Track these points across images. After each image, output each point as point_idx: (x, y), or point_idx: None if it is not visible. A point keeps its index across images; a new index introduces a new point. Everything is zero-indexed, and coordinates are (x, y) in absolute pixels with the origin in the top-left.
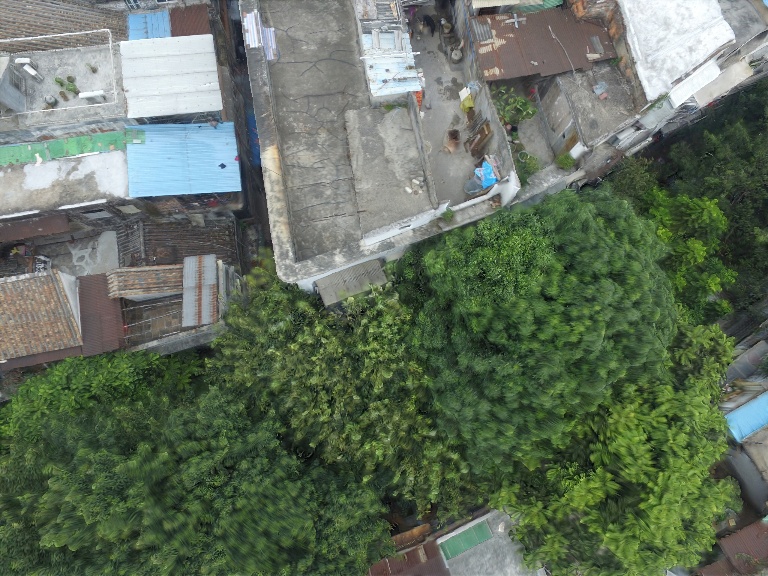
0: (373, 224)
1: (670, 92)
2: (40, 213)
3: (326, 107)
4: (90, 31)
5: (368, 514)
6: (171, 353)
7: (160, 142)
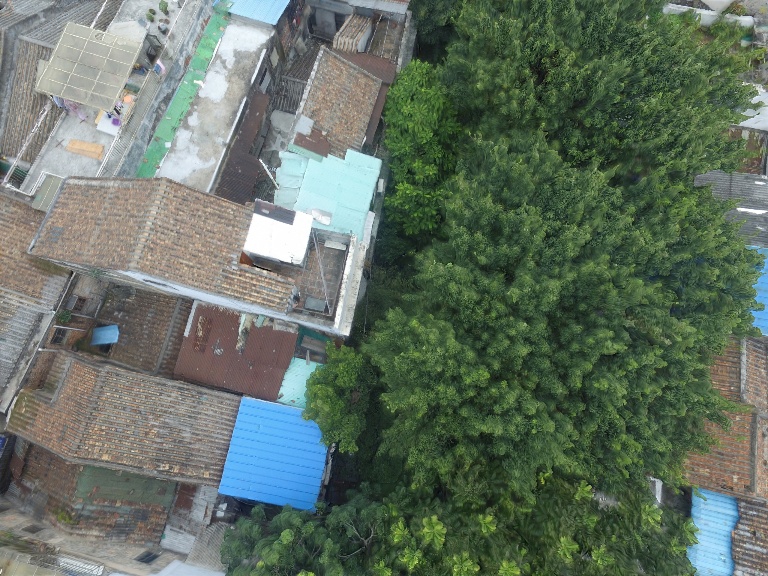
0: None
1: None
2: (247, 100)
3: None
4: None
5: None
6: None
7: None
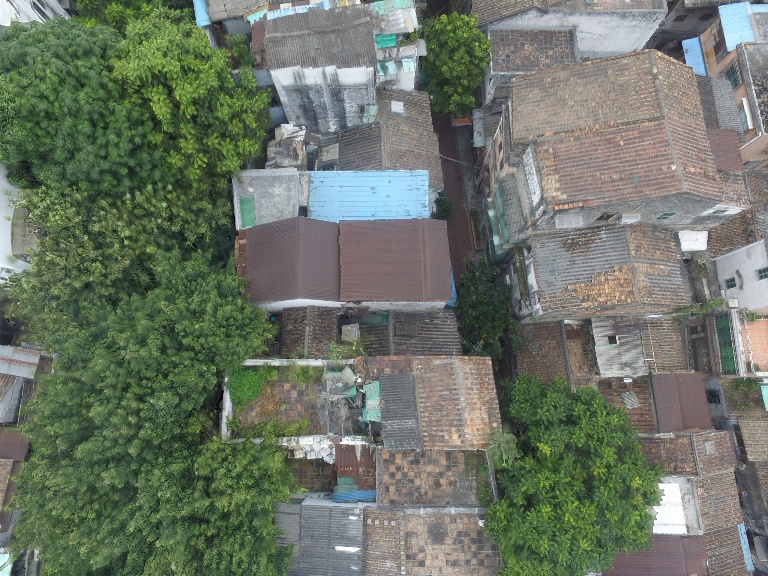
0: None
1: None
2: None
3: None
4: None
5: None
6: None
7: None
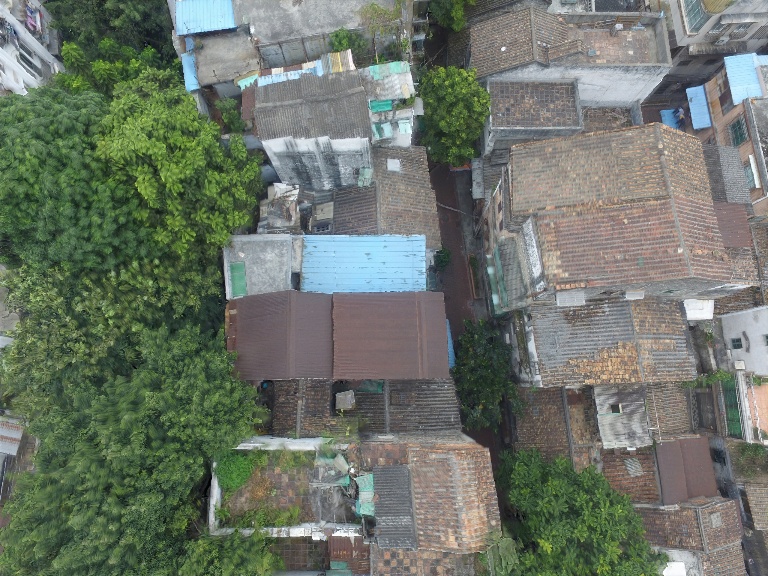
0: None
1: None
2: None
3: None
4: None
5: None
6: None
7: None
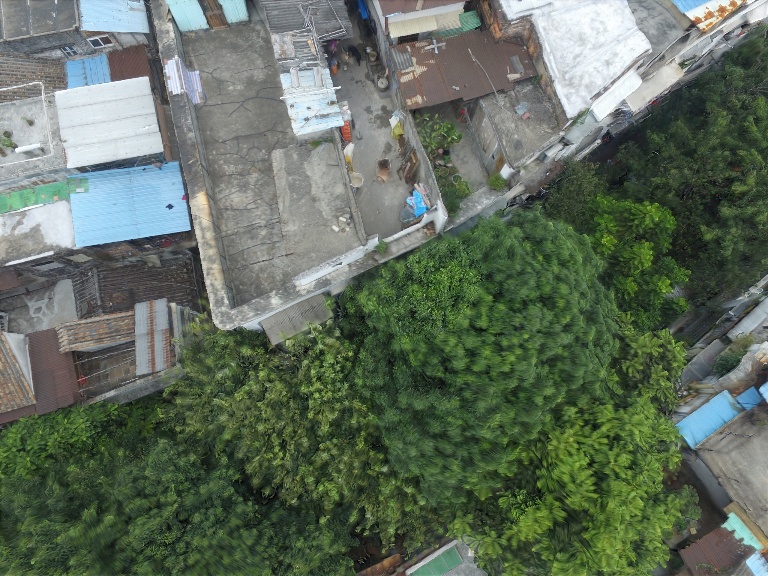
0: (302, 266)
1: (592, 106)
2: None
3: (256, 146)
4: (22, 85)
5: (331, 553)
6: (131, 401)
7: (104, 189)
